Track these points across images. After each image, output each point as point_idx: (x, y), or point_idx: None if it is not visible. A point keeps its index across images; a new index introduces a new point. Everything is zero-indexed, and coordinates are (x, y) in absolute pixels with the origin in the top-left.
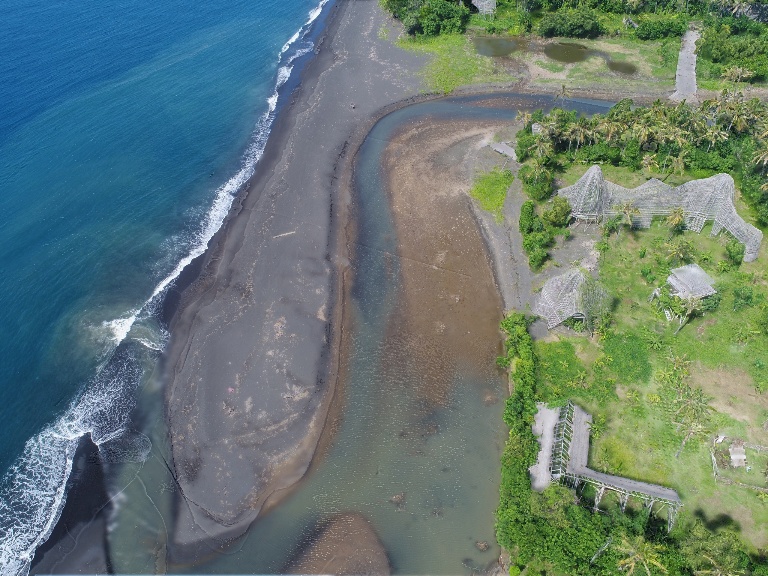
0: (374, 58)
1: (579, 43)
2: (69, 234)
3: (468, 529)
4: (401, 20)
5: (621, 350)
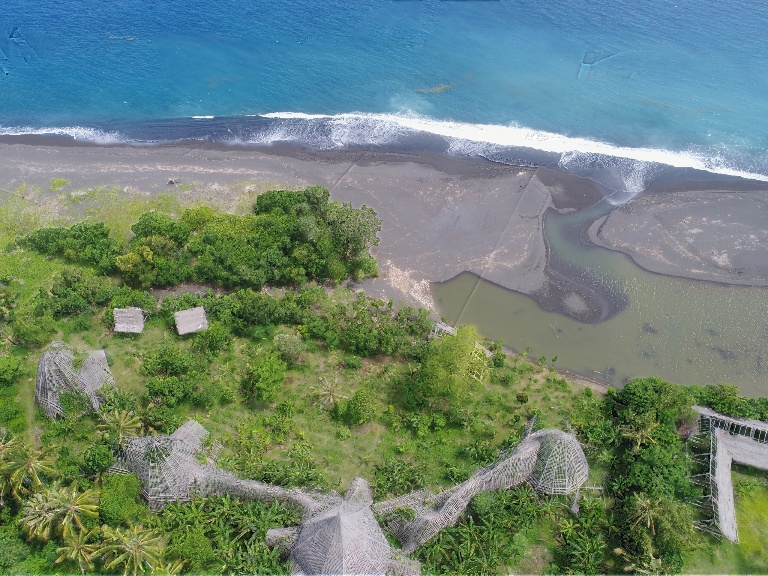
0: None
1: None
2: None
3: (639, 374)
4: None
5: None
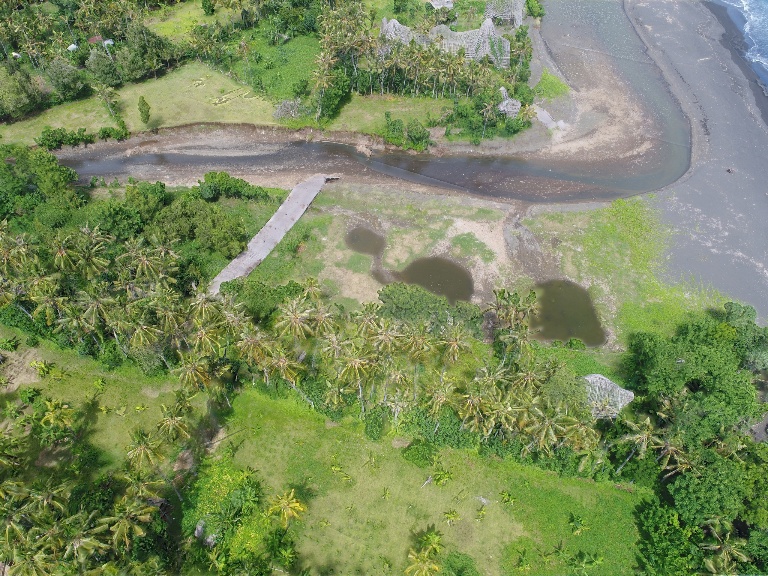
0: (761, 266)
1: None
2: None
3: None
4: None
5: (481, 7)
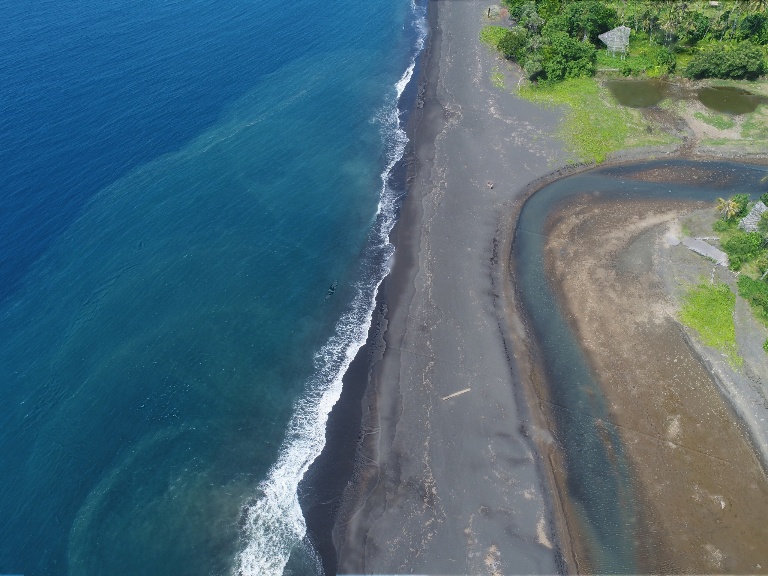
0: (496, 114)
1: (738, 86)
2: (166, 386)
3: None
4: (519, 63)
5: None
